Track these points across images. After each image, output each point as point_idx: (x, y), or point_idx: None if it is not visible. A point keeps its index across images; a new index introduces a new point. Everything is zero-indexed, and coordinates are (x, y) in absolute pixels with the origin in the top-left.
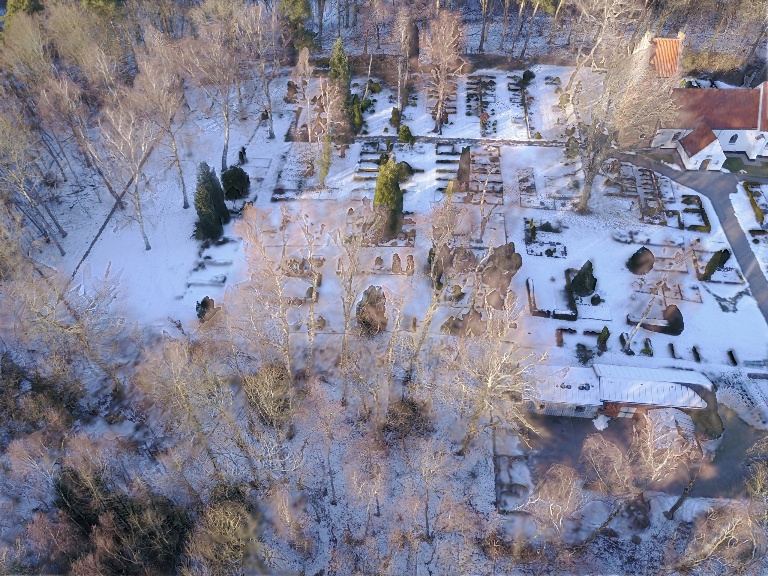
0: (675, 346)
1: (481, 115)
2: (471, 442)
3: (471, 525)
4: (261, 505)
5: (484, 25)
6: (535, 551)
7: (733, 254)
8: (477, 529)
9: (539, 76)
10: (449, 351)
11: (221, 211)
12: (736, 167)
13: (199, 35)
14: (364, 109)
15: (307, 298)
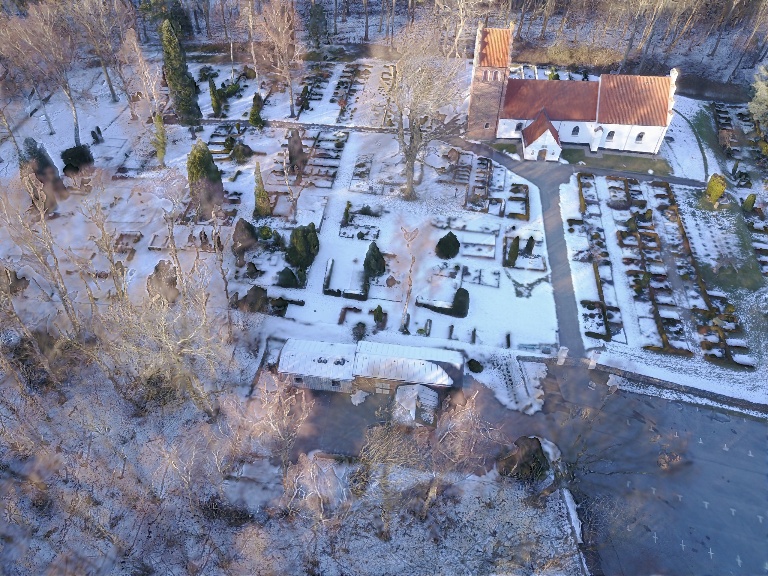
0: (456, 328)
1: (338, 102)
2: None
3: (198, 489)
4: (18, 465)
5: None
6: (248, 515)
7: (545, 242)
8: (201, 493)
9: None
10: None
11: (55, 187)
12: (576, 158)
13: (29, 14)
14: (232, 94)
15: None
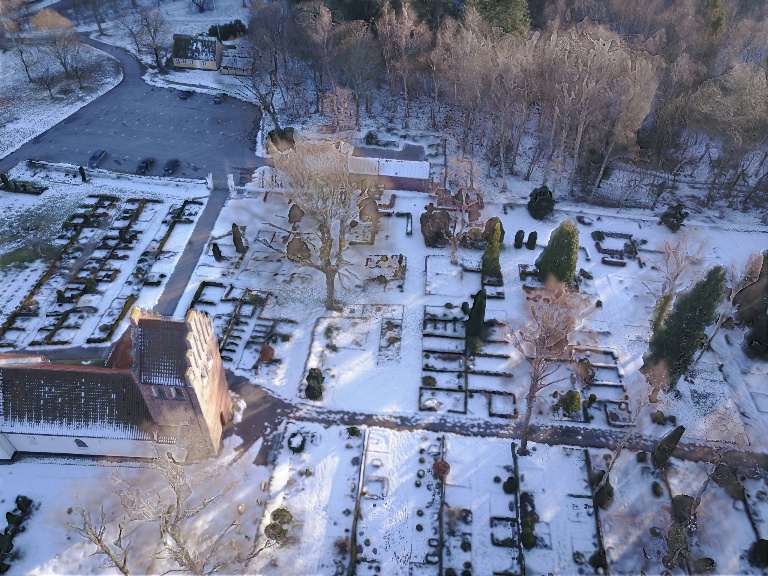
0: None
1: None
2: None
3: None
4: None
5: None
6: None
7: (197, 266)
8: None
9: None
10: None
11: None
12: None
13: None
14: None
15: (601, 232)
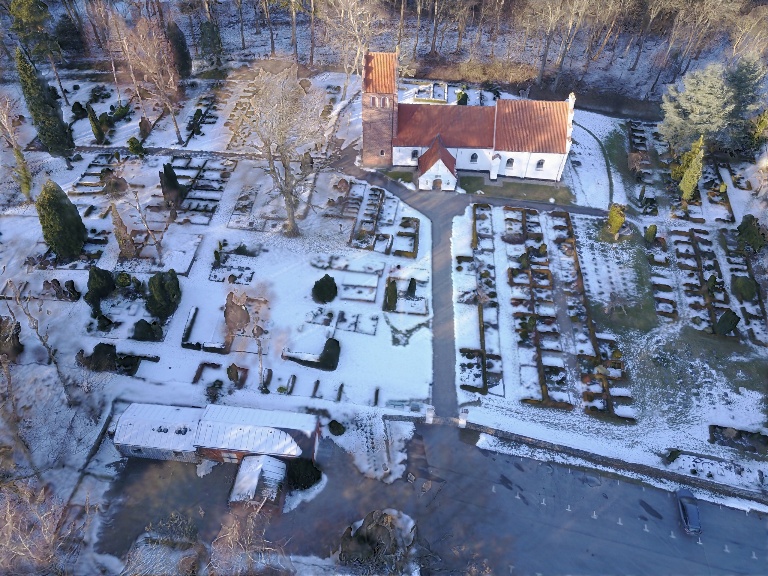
0: (323, 383)
1: (230, 127)
2: (50, 489)
3: None
4: None
5: (271, 30)
6: None
7: (430, 282)
8: None
9: (322, 85)
10: (73, 387)
11: None
12: (474, 187)
13: None
14: (120, 117)
15: None
